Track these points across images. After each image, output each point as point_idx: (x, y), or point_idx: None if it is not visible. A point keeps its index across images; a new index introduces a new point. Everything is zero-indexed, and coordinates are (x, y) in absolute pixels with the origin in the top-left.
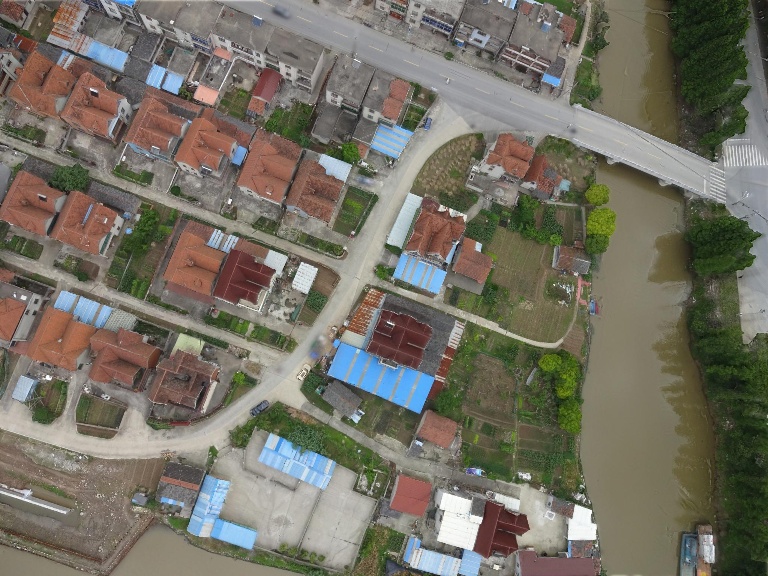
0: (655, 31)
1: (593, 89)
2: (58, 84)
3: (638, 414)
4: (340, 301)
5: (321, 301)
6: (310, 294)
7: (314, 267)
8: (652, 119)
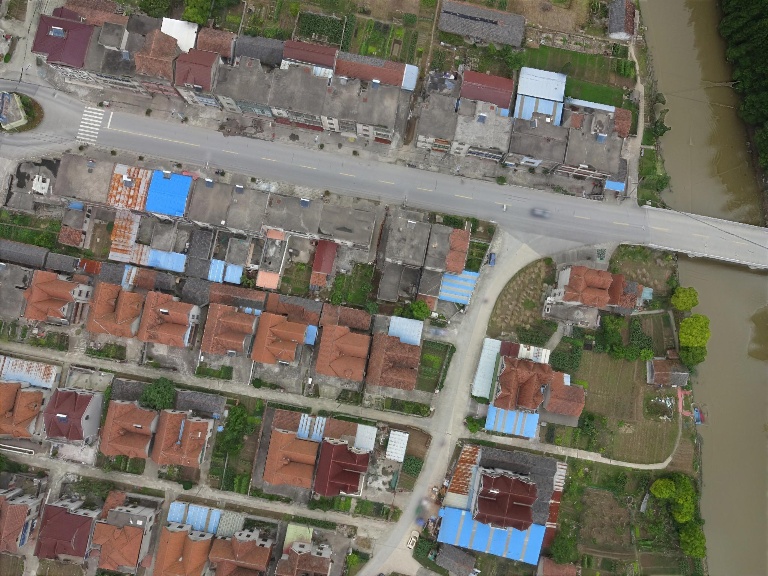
0: (717, 91)
1: (660, 180)
2: (129, 309)
3: (762, 508)
4: (436, 460)
5: (417, 465)
6: (405, 460)
7: (404, 433)
8: (727, 183)
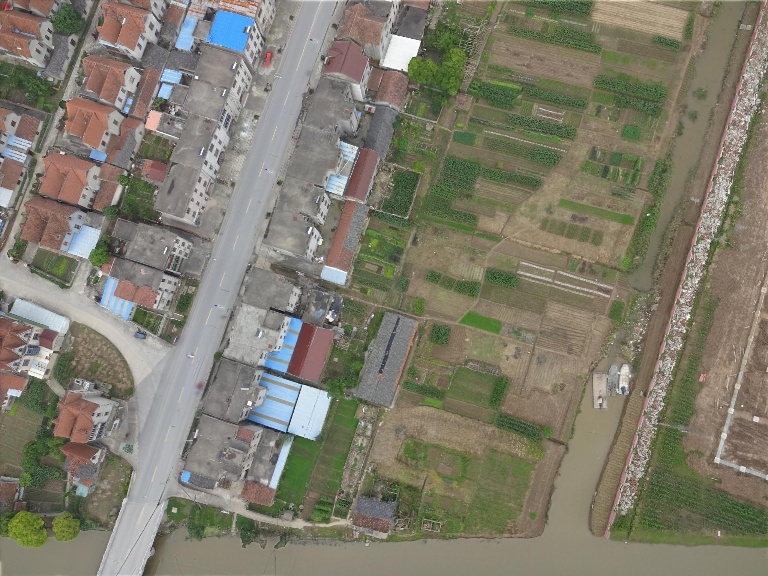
0: None
1: (197, 528)
2: None
3: None
4: None
5: None
6: None
7: None
8: None
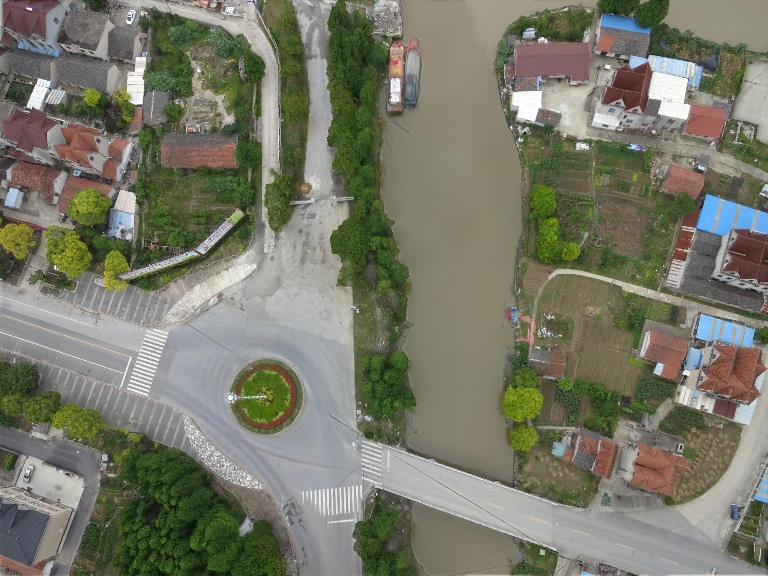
0: None
1: None
2: None
3: (437, 219)
4: None
5: None
6: None
7: None
8: None
